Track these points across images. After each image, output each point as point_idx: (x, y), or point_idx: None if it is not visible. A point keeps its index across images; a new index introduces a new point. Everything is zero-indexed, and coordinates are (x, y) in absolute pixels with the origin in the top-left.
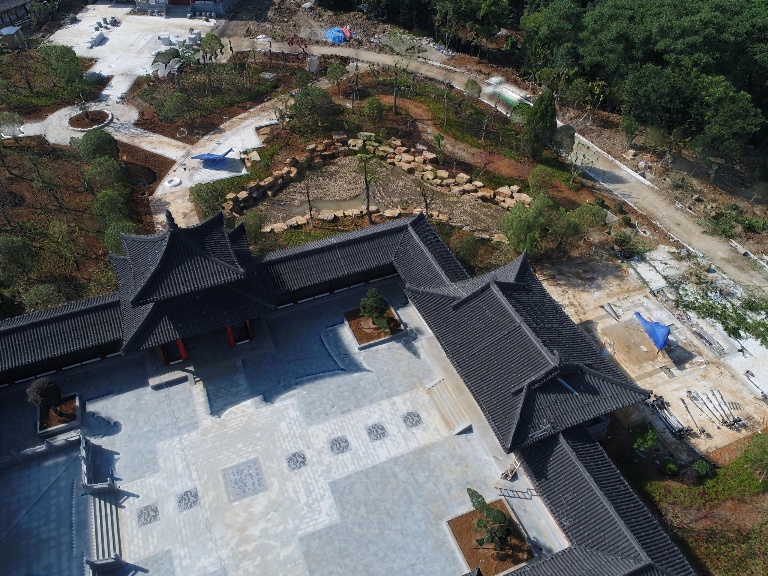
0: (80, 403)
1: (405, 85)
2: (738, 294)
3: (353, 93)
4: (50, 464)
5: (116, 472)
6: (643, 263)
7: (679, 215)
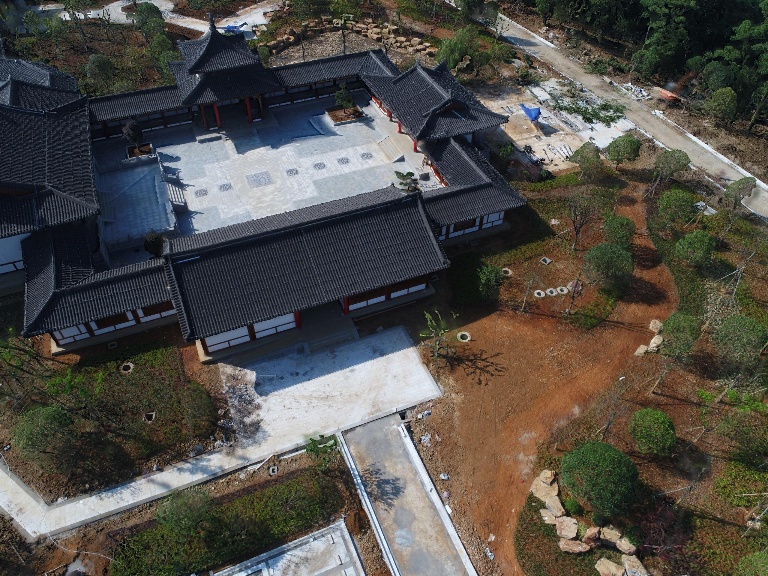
0: (153, 148)
1: None
2: (598, 102)
3: None
4: (139, 170)
5: (180, 177)
6: (537, 87)
7: (571, 63)
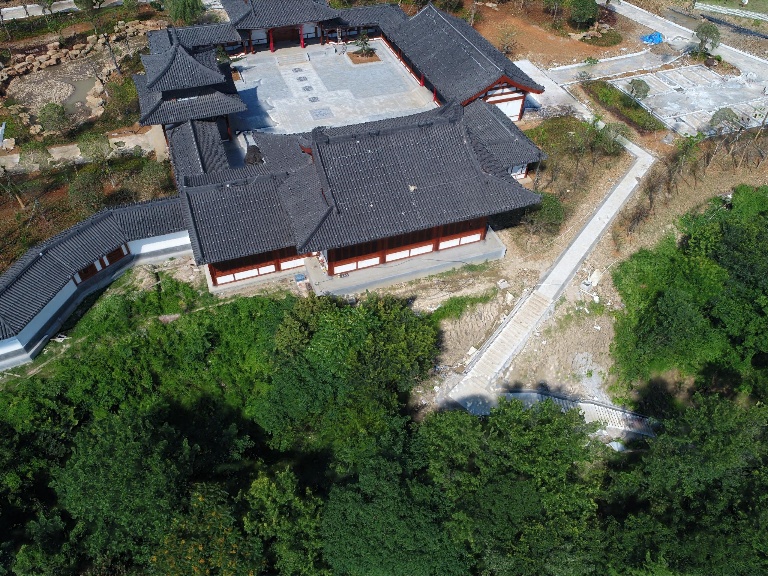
0: None
1: None
2: None
3: None
4: None
5: None
6: (212, 6)
7: None
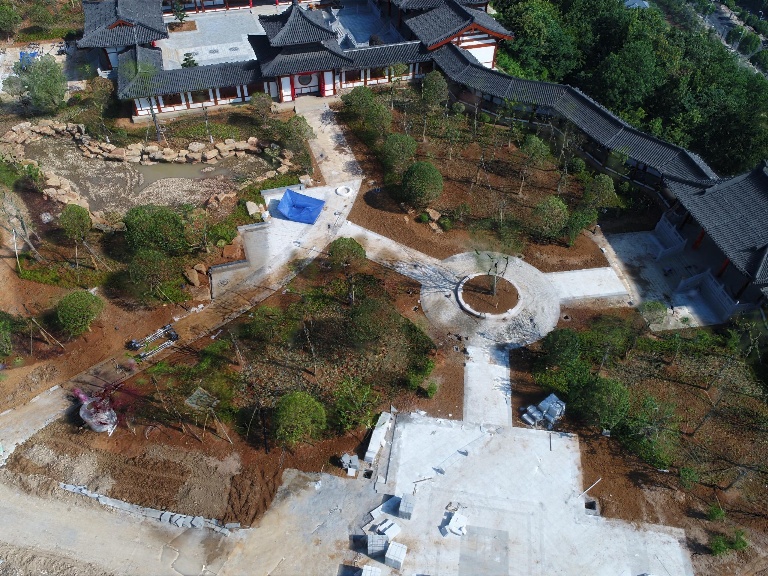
0: None
1: None
2: None
3: None
4: None
5: None
6: None
7: None
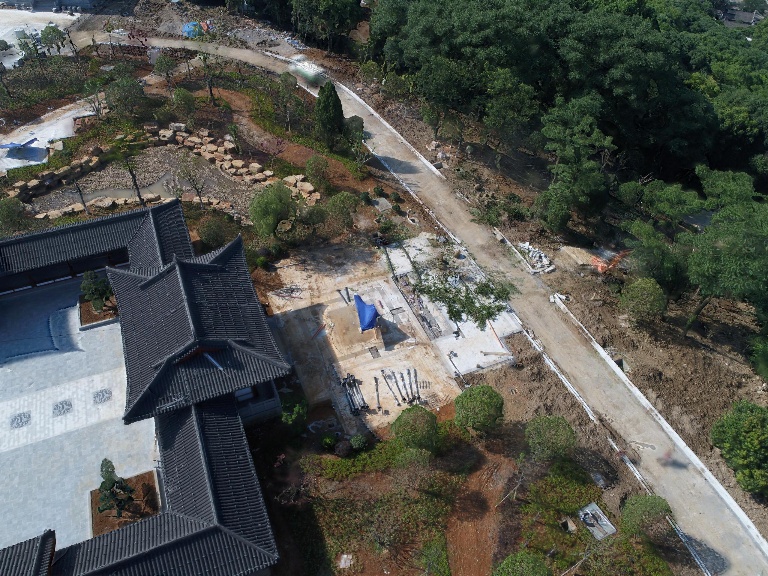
0: None
1: (239, 78)
2: (477, 279)
3: (169, 85)
4: None
5: None
6: (398, 249)
7: (455, 204)
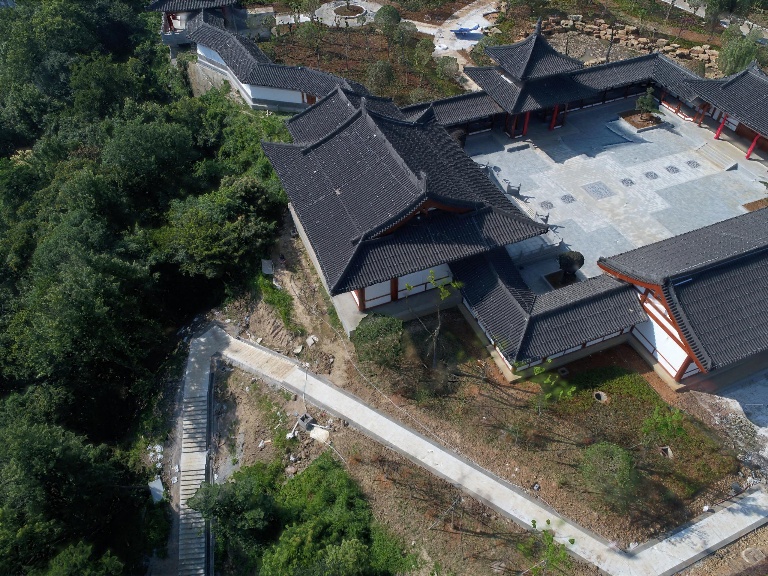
0: None
1: None
2: None
3: None
4: None
5: None
6: None
7: None
